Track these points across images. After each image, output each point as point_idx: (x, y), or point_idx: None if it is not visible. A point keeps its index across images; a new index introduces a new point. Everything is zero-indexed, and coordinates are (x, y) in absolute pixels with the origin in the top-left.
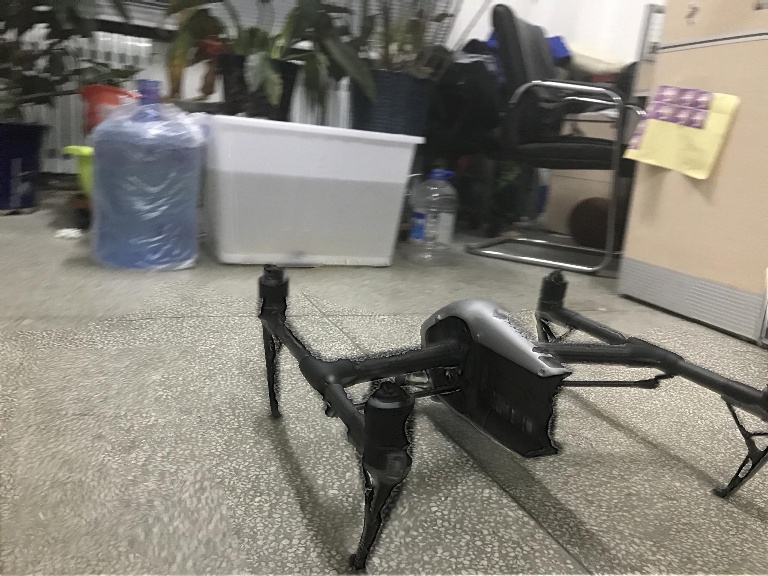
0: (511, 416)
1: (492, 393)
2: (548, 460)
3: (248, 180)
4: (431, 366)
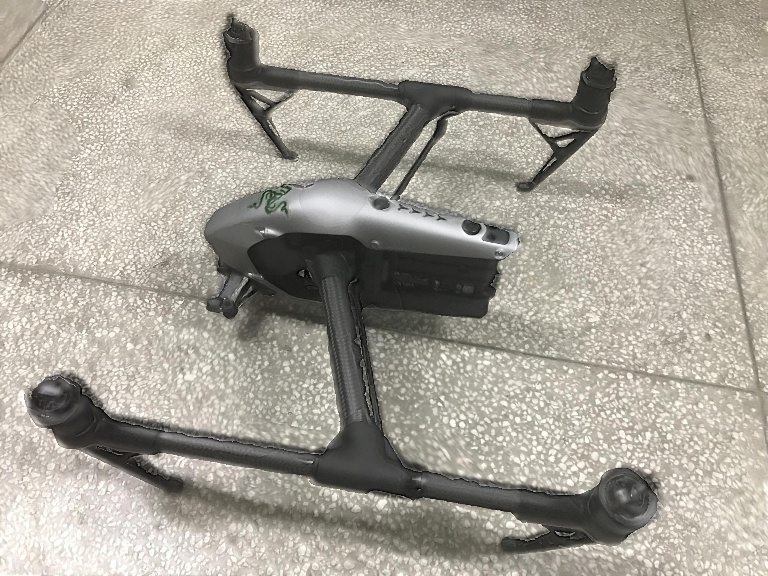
0: (435, 286)
1: (394, 274)
2: None
3: None
4: None
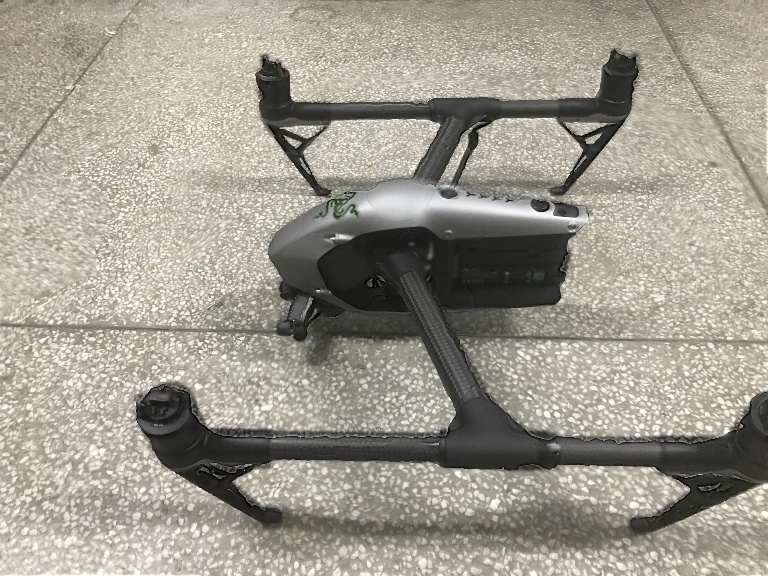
0: (505, 278)
1: (463, 271)
2: None
3: None
4: None
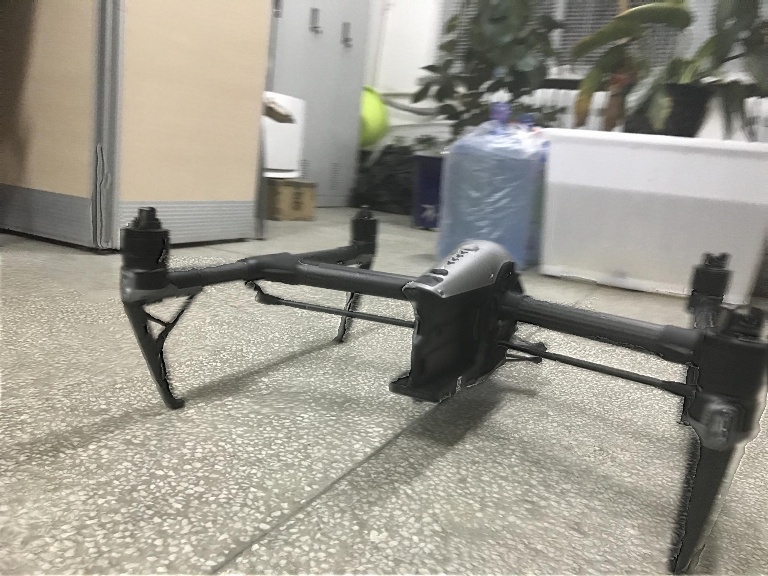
0: None
1: None
2: (507, 446)
3: (571, 187)
4: (397, 294)
